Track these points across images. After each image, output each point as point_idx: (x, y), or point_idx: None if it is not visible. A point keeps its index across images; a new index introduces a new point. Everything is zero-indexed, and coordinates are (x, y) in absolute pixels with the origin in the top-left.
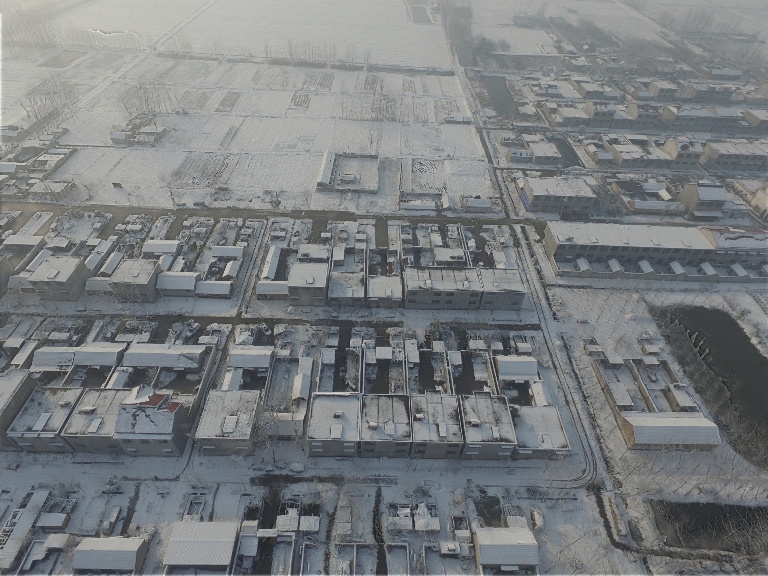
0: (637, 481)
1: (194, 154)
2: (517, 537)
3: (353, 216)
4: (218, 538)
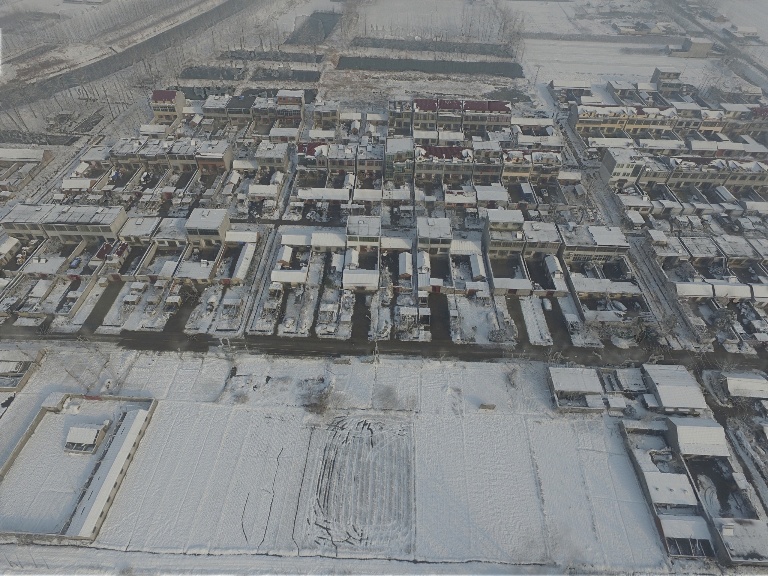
0: (67, 149)
1: (400, 545)
2: (148, 128)
3: (123, 339)
4: (277, 132)
